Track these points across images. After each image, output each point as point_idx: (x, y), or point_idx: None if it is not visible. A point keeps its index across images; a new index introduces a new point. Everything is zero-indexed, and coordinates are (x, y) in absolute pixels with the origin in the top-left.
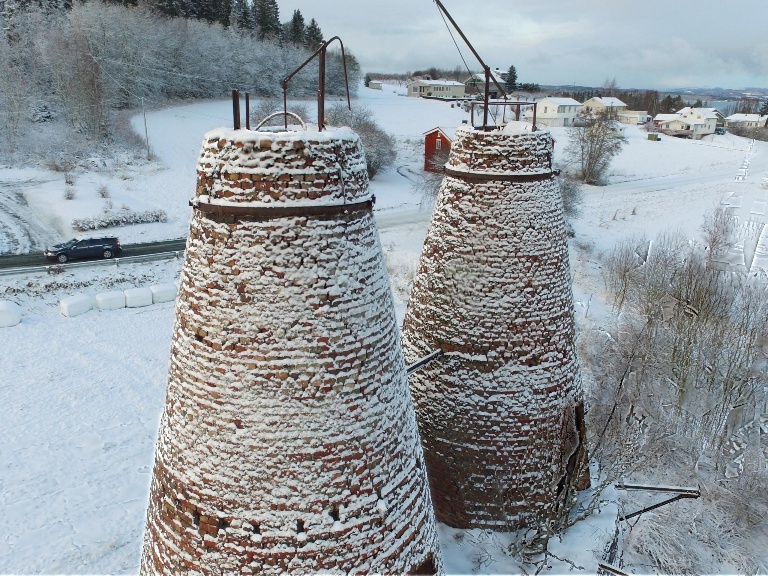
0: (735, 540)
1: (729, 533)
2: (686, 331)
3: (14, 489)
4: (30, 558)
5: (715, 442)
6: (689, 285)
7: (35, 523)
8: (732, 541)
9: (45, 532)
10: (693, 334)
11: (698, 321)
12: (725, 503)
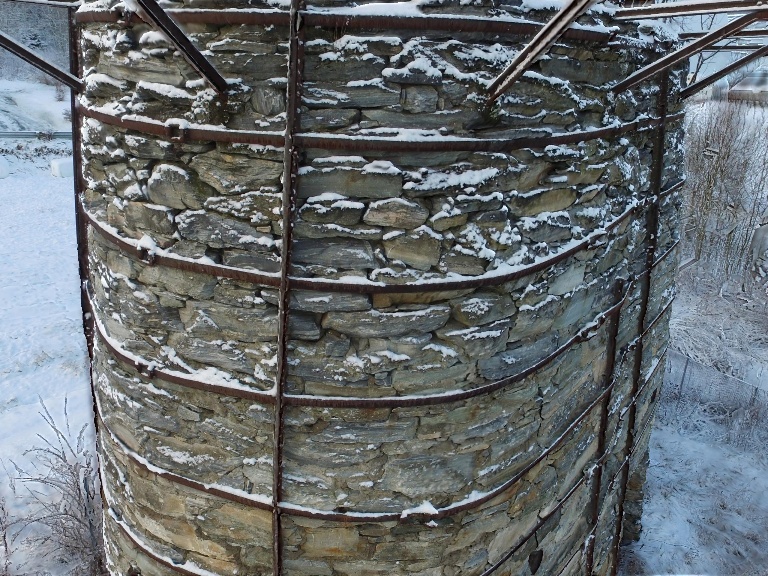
0: (766, 346)
1: (759, 341)
2: (706, 173)
3: (2, 278)
4: (19, 325)
5: (741, 261)
6: (709, 125)
7: (25, 302)
8: (763, 347)
9: (35, 309)
10: (714, 174)
11: (719, 158)
12: (753, 319)
